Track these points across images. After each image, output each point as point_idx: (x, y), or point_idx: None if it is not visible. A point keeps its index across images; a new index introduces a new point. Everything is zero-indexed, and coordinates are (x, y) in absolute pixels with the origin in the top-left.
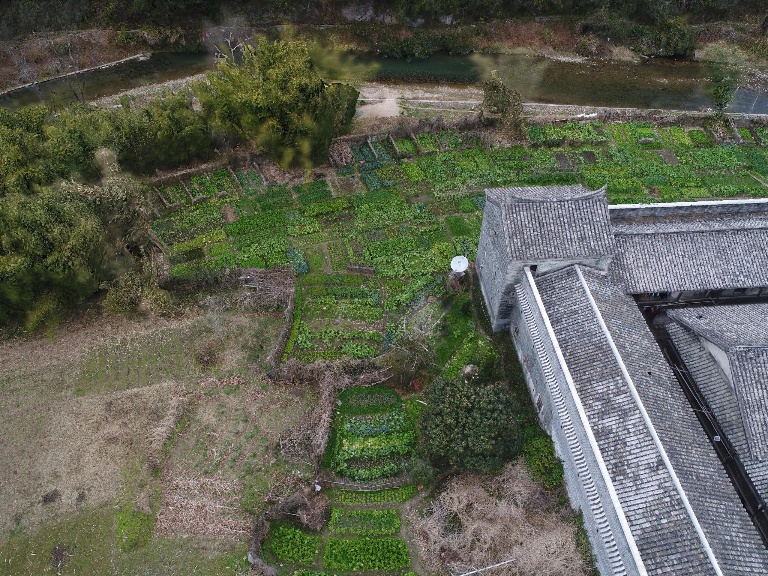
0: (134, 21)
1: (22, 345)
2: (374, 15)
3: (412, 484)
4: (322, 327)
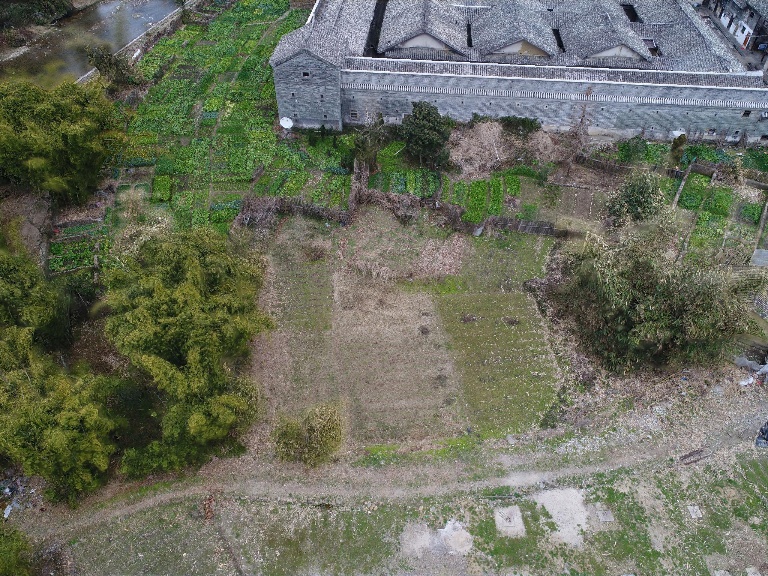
0: None
1: (254, 378)
2: None
3: None
4: (307, 199)
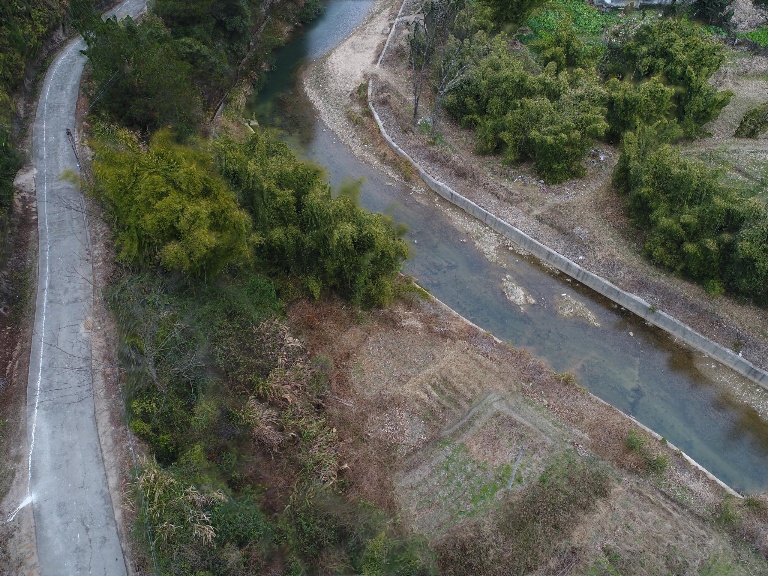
0: (214, 100)
1: None
2: (271, 1)
3: None
4: None
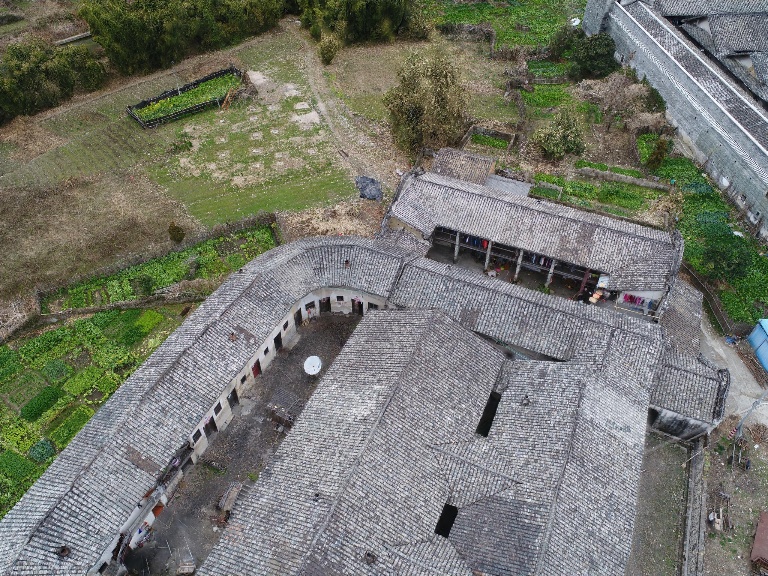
0: None
1: (366, 49)
2: None
3: (567, 83)
4: None
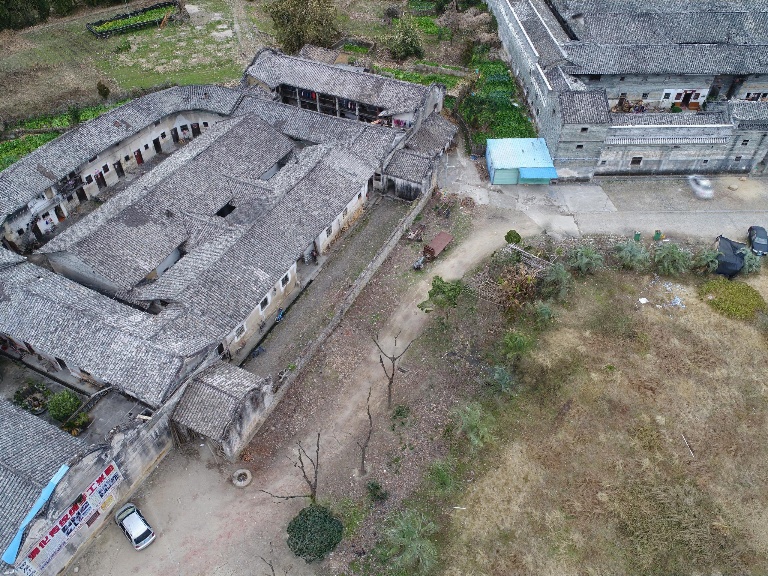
0: None
1: None
2: None
3: (436, 15)
4: None
